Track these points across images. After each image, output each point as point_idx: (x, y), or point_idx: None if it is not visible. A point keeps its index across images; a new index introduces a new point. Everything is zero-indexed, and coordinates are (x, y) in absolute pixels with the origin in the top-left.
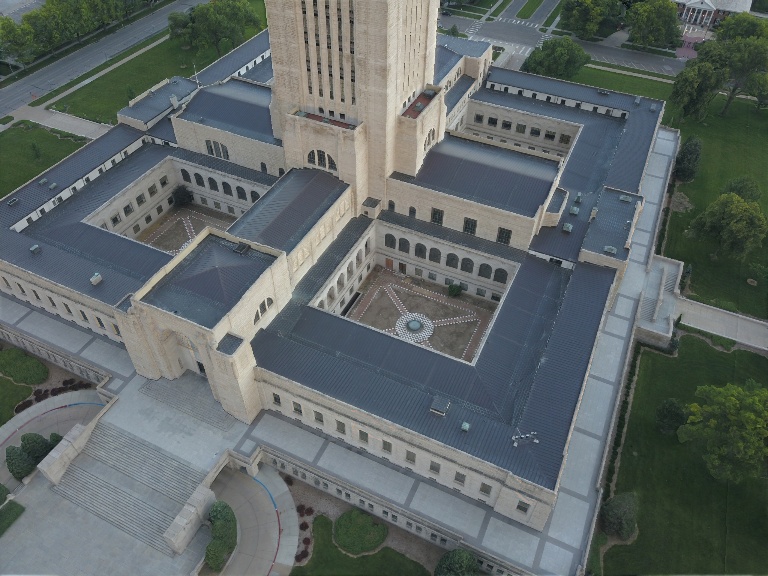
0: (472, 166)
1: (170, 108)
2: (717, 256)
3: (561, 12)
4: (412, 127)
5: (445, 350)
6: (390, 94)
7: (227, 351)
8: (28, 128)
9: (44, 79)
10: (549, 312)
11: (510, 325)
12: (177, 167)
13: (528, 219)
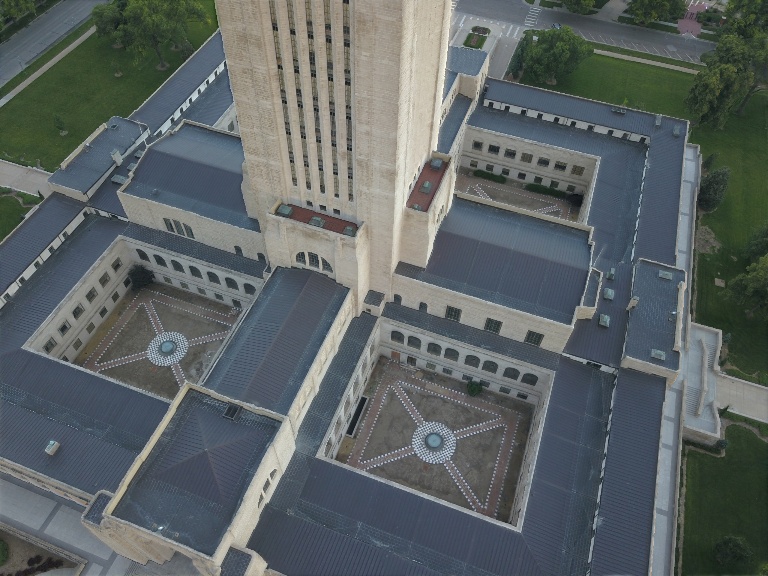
0: (491, 251)
1: (113, 166)
2: (753, 312)
3: None
4: (423, 221)
5: (472, 472)
6: (398, 193)
7: (233, 575)
8: None
9: None
10: (594, 438)
11: (553, 464)
12: (131, 247)
13: (565, 327)
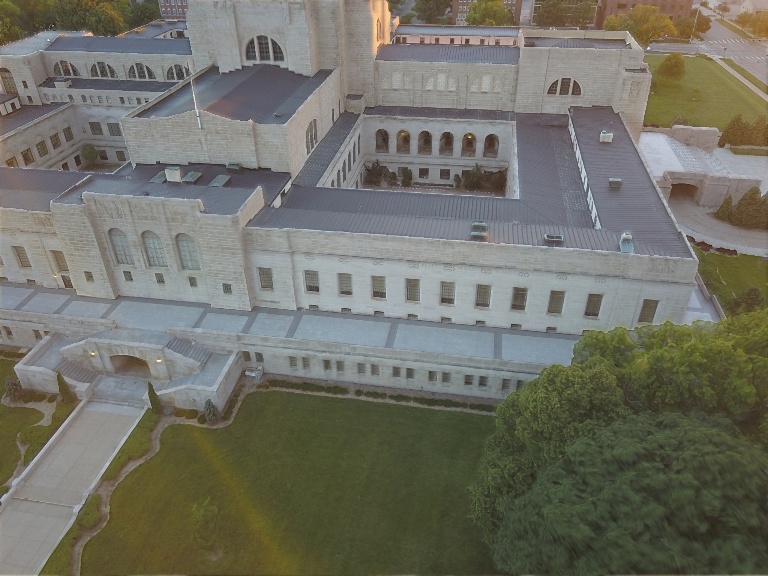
0: None
1: None
2: None
3: None
4: None
5: None
6: None
7: None
8: None
9: None
10: None
11: None
12: None
13: None
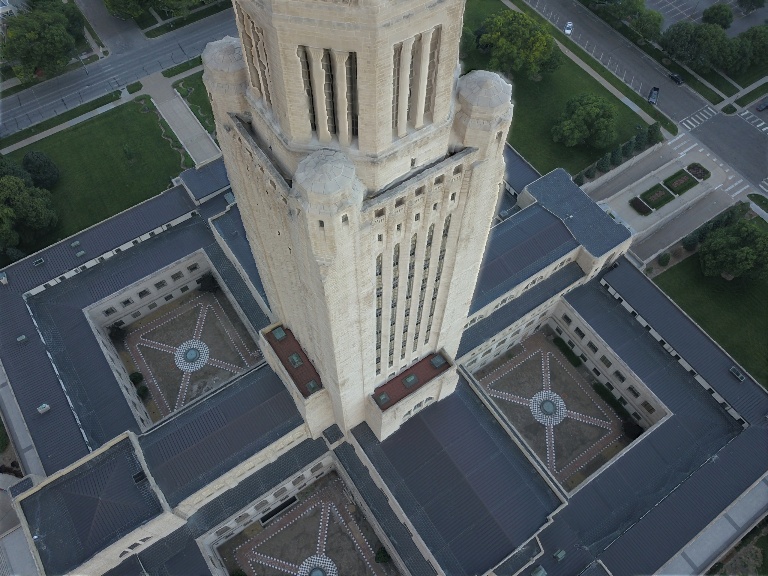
0: (446, 465)
1: None
2: None
3: None
4: (378, 415)
5: None
6: (350, 391)
7: None
8: (144, 109)
9: (193, 38)
10: None
11: None
12: None
13: None
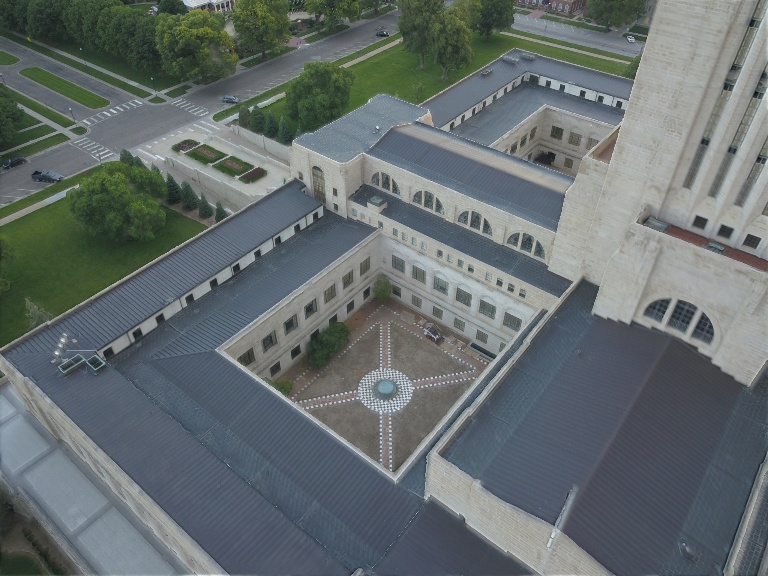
0: None
1: None
2: None
3: (180, 62)
4: None
5: None
6: None
7: None
8: None
9: None
10: None
11: None
12: None
13: None
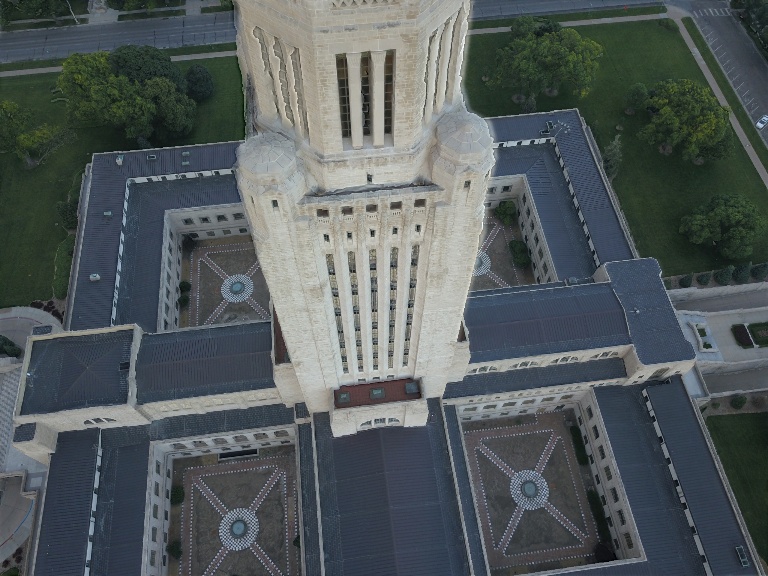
0: (379, 488)
1: None
2: None
3: None
4: None
5: (225, 574)
6: (308, 375)
7: (19, 435)
8: None
9: None
10: None
11: None
12: None
13: None
